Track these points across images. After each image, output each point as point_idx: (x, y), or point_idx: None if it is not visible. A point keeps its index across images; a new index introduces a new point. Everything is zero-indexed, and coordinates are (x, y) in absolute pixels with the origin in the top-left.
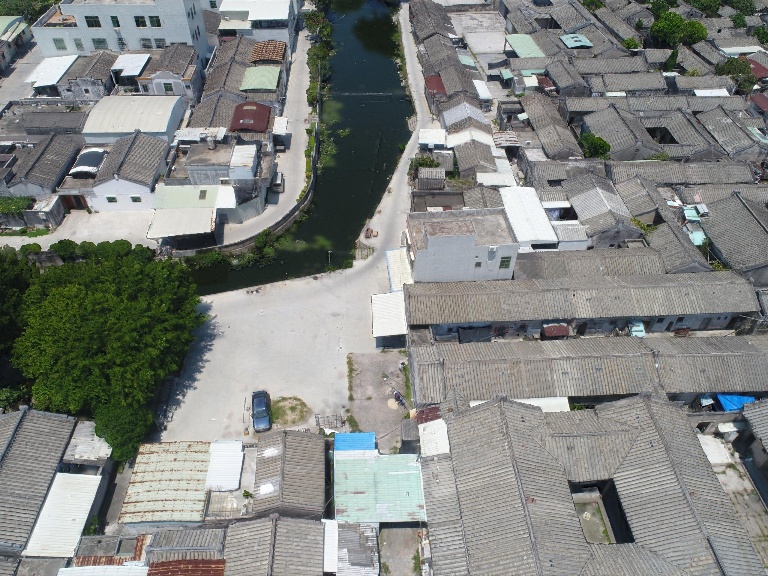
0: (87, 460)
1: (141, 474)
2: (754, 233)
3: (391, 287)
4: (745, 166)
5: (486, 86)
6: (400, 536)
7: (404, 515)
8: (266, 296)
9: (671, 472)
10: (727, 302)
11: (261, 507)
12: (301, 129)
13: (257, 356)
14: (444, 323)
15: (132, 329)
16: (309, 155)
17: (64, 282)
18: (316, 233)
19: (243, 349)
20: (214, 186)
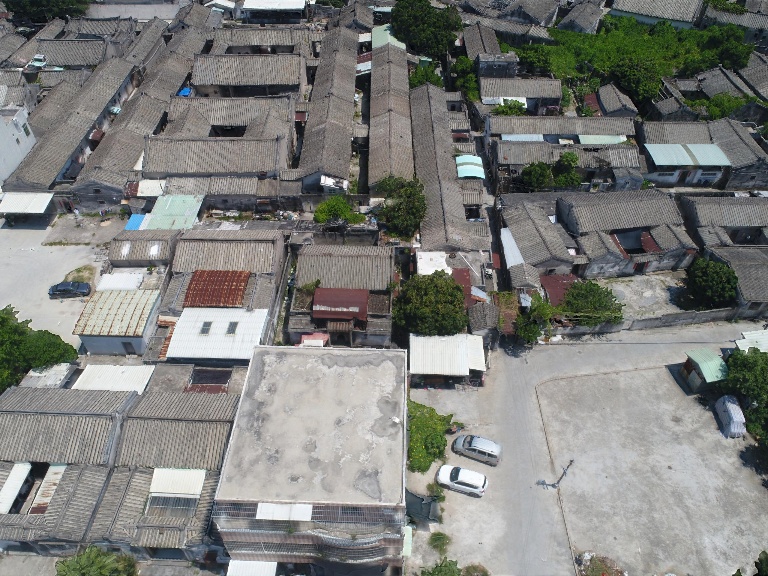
0: (66, 376)
1: (103, 328)
2: (78, 46)
3: None
4: (11, 35)
5: None
6: None
7: (197, 204)
8: None
9: (219, 101)
10: (122, 70)
11: (167, 251)
12: None
13: (4, 300)
14: (59, 172)
15: None
16: None
17: None
18: None
19: None
20: None
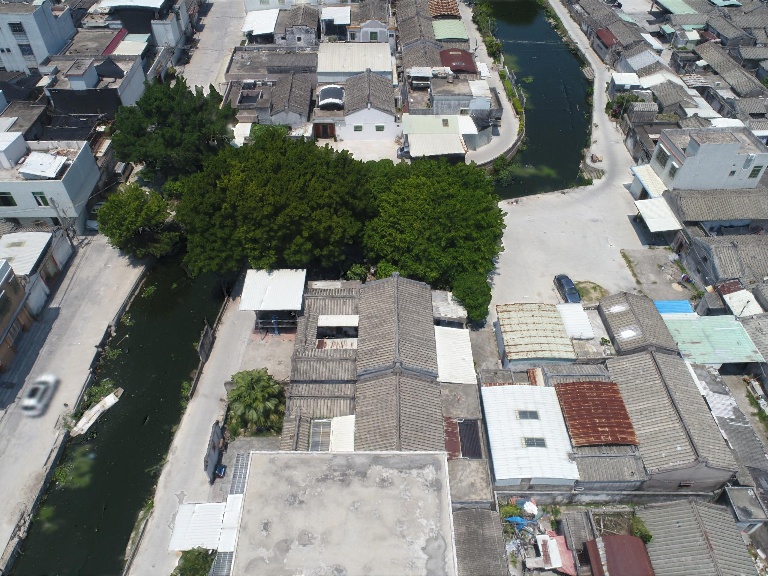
0: (451, 318)
1: (508, 326)
2: None
3: (650, 194)
4: None
5: (654, 39)
6: (728, 381)
7: (743, 358)
8: (526, 206)
9: None
10: None
11: (631, 346)
12: (491, 76)
13: (541, 251)
14: (714, 220)
15: (477, 211)
16: (513, 95)
17: (400, 176)
18: (541, 160)
19: (526, 246)
20: (453, 116)
